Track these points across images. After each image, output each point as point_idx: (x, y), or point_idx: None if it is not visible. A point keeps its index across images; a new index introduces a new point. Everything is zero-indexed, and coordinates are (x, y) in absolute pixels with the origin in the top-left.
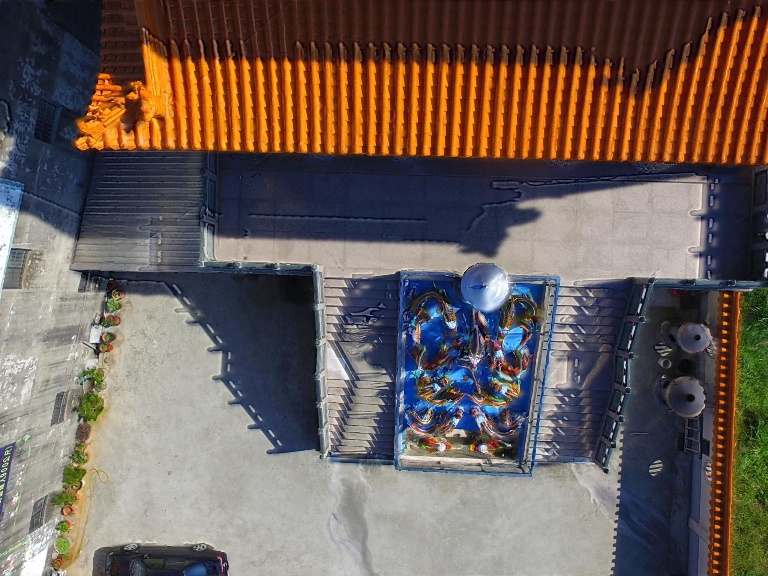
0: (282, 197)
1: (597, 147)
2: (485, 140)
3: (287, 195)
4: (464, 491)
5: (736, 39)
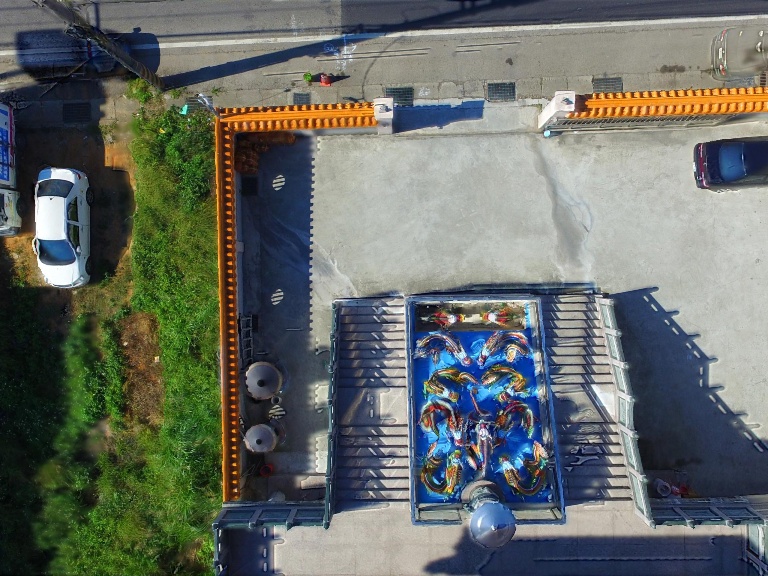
0: None
1: None
2: None
3: None
4: (460, 263)
5: None
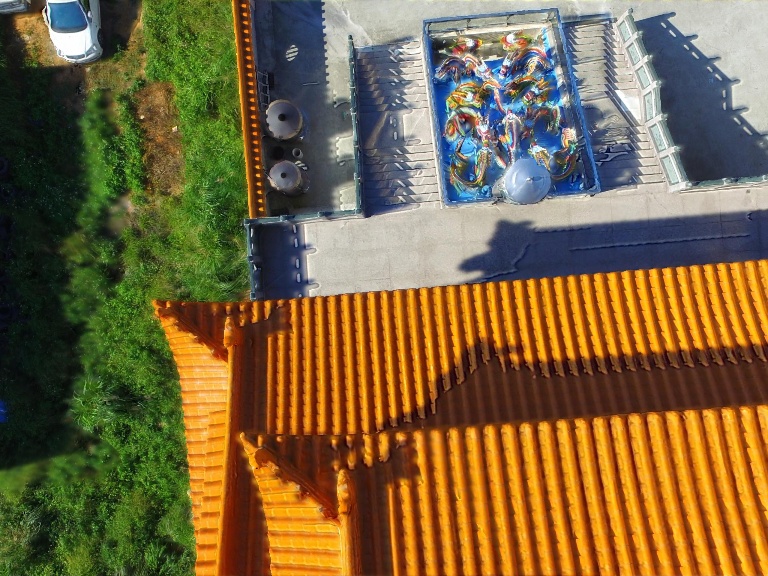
0: (718, 257)
1: (505, 293)
2: (613, 288)
3: (713, 259)
4: (474, 4)
5: (405, 398)
